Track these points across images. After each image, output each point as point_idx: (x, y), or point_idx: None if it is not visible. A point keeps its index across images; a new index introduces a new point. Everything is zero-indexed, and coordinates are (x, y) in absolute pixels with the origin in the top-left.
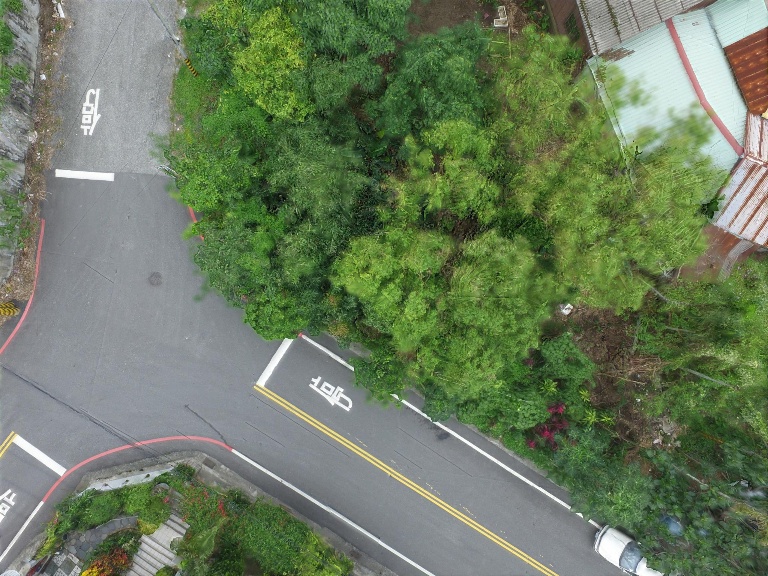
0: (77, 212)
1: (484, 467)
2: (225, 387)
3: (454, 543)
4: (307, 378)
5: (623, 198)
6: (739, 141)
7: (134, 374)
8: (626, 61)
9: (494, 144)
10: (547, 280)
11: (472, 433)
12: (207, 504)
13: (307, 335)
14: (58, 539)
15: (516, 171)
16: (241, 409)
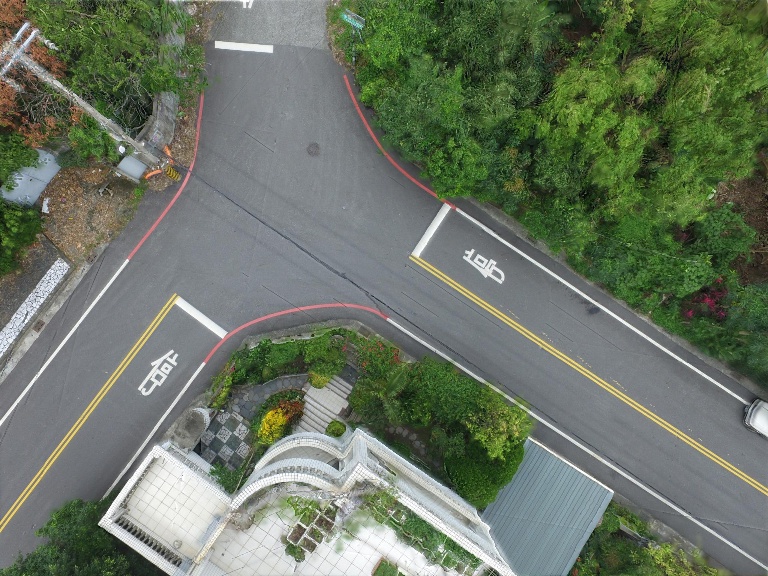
0: (237, 82)
1: (634, 342)
2: (381, 257)
3: (605, 415)
4: (461, 250)
5: None
6: None
7: None
8: None
9: None
10: None
11: (622, 308)
12: (383, 354)
13: (461, 208)
14: None
15: (698, 26)
16: (396, 279)
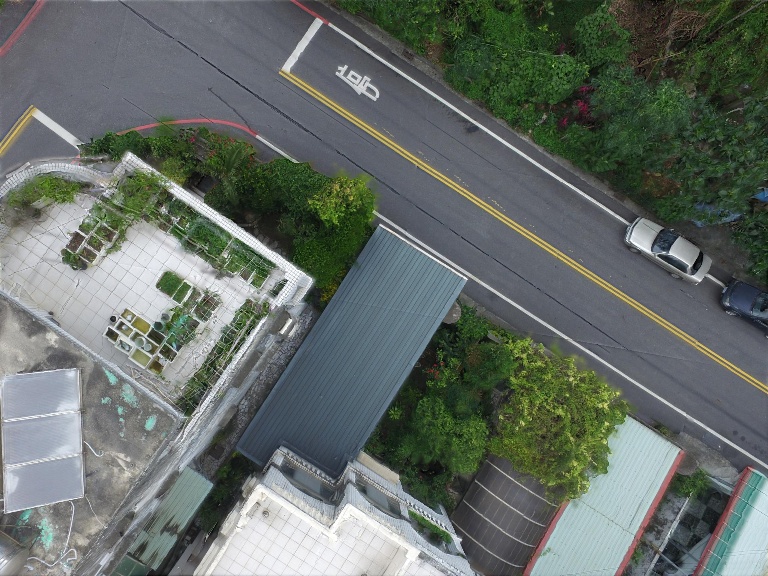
0: None
1: (513, 161)
2: (249, 72)
3: (482, 236)
4: (333, 67)
5: None
6: None
7: (156, 54)
8: None
9: None
10: None
11: (501, 128)
12: None
13: (334, 23)
14: None
15: None
16: (266, 95)
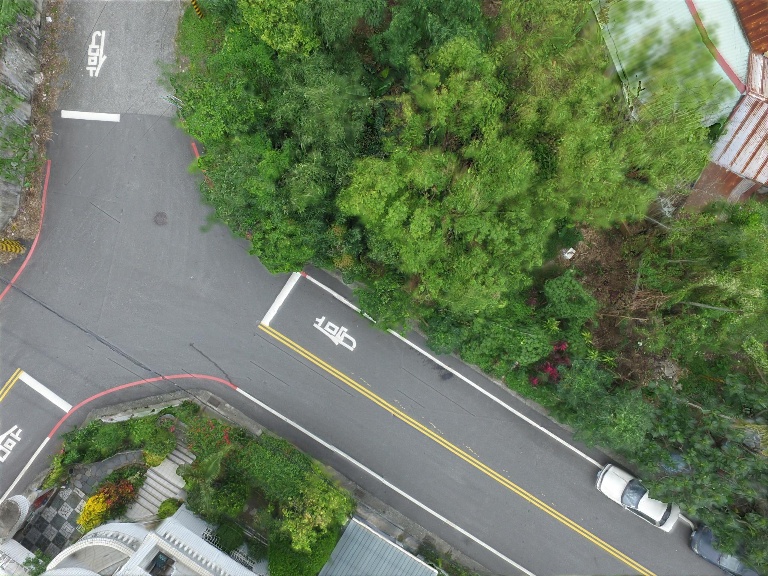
0: (83, 152)
1: (487, 407)
2: (230, 326)
3: (457, 482)
4: (311, 318)
5: (626, 135)
6: (741, 79)
7: (139, 313)
8: (629, 1)
9: (499, 65)
10: (550, 224)
11: (475, 373)
12: (212, 434)
13: (311, 275)
14: (64, 472)
15: (520, 102)
16: (246, 348)
